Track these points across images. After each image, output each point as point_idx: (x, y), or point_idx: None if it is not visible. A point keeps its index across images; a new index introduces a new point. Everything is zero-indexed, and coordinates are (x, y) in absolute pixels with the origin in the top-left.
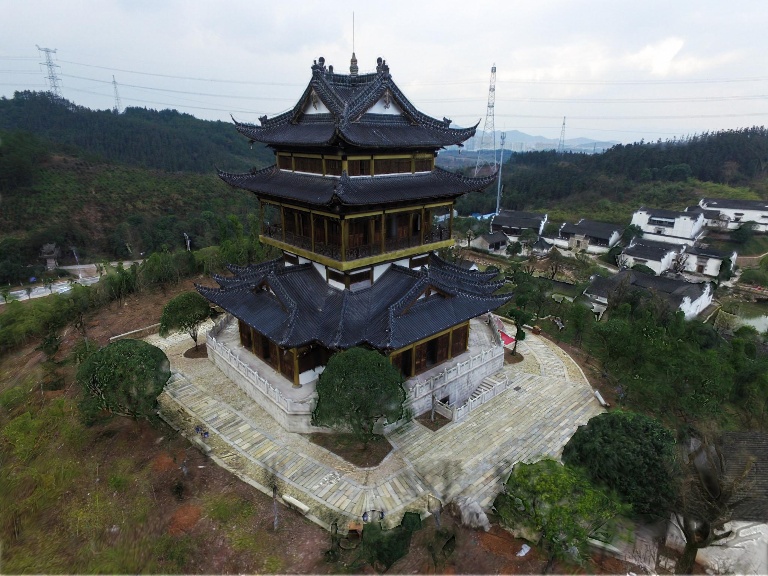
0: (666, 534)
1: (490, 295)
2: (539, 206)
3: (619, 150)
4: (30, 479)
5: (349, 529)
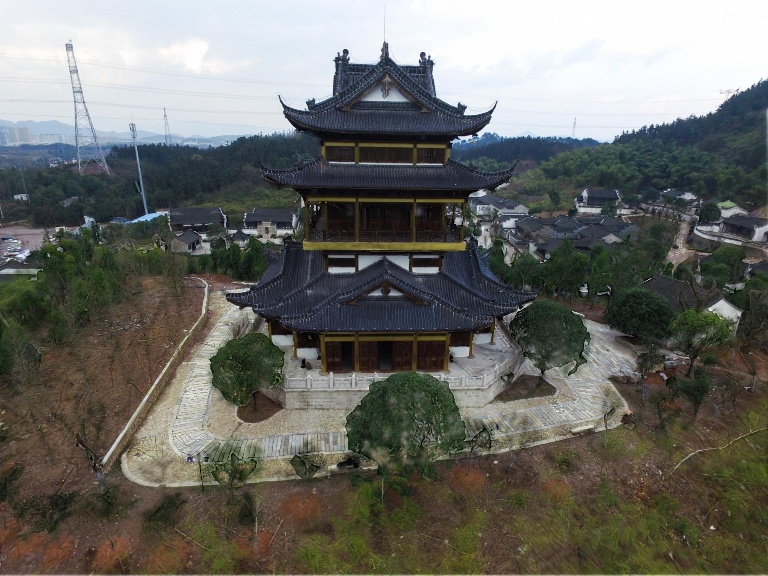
0: (667, 342)
1: None
2: (201, 201)
3: (245, 142)
4: None
5: (629, 415)
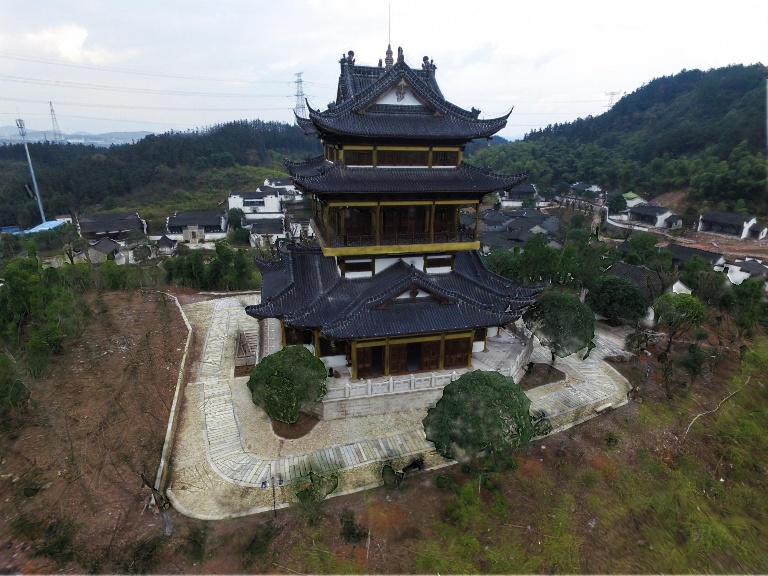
0: (637, 322)
1: None
2: (112, 205)
3: (155, 140)
4: None
5: None
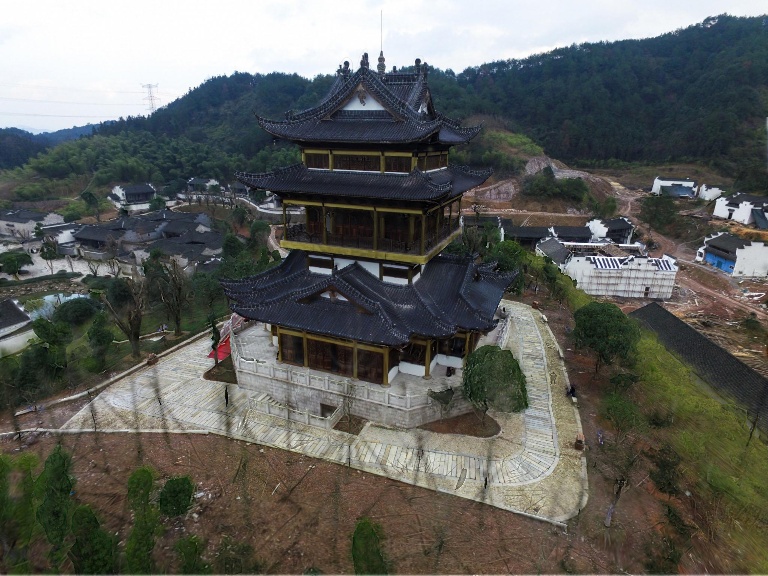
0: None
1: None
2: None
3: None
4: (678, 443)
5: None
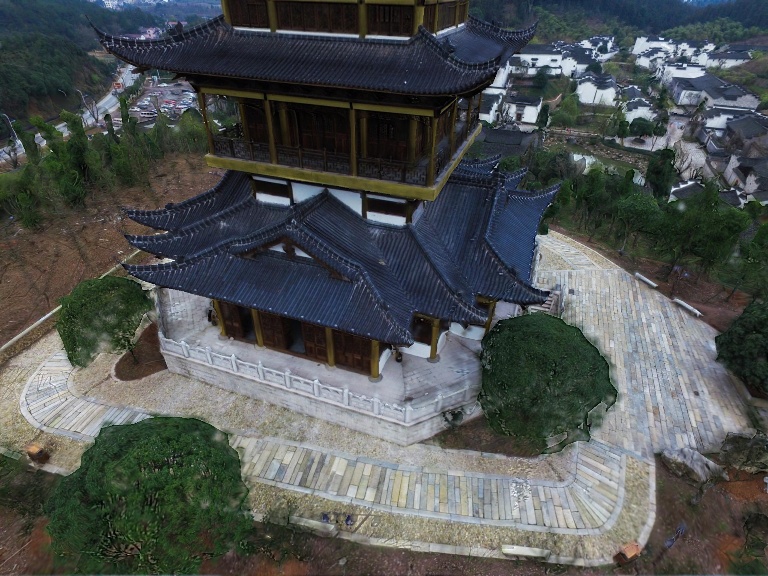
0: None
1: (538, 192)
2: None
3: None
4: None
5: (629, 558)
